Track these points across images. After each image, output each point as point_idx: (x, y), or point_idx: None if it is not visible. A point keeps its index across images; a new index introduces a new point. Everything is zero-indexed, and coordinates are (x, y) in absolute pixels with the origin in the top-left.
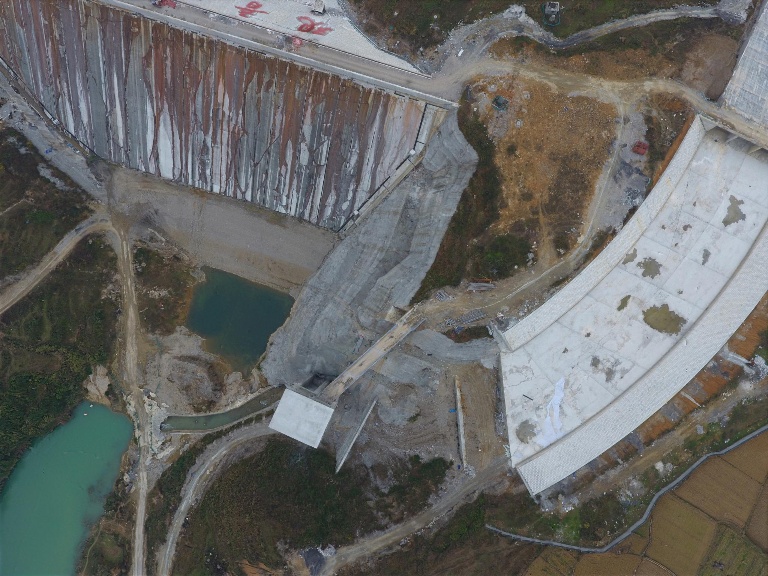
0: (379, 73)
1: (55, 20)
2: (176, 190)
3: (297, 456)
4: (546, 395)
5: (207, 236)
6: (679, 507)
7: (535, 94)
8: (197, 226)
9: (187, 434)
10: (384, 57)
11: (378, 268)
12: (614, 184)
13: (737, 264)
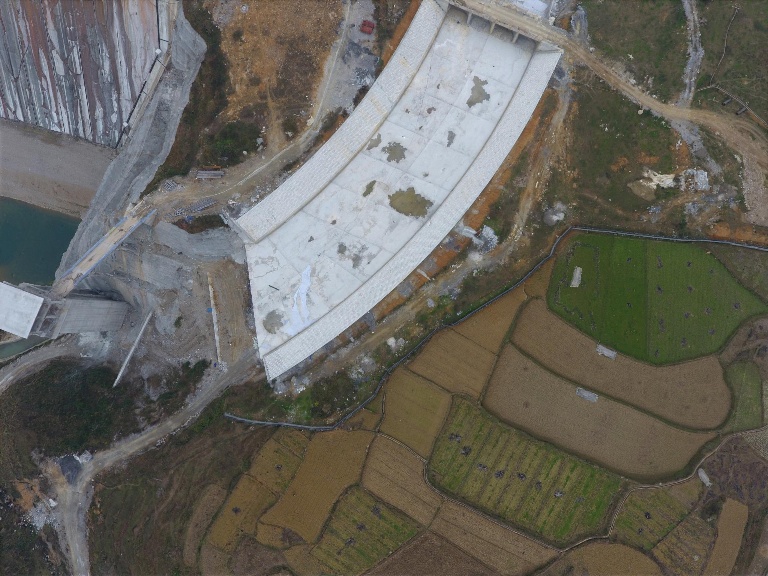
0: None
1: None
2: None
3: (74, 373)
4: (293, 284)
5: None
6: (412, 381)
7: None
8: None
9: None
10: None
11: (132, 172)
12: (343, 65)
13: (482, 144)
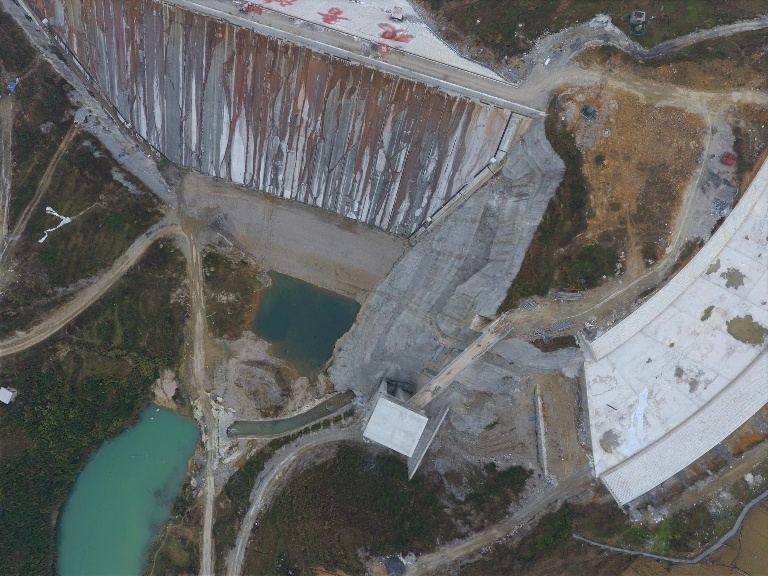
0: (465, 81)
1: (137, 25)
2: (247, 195)
3: (370, 463)
4: (630, 405)
5: (275, 241)
6: None
7: (623, 104)
8: (266, 231)
9: (254, 439)
10: (468, 65)
11: (457, 276)
12: (702, 195)
13: None
